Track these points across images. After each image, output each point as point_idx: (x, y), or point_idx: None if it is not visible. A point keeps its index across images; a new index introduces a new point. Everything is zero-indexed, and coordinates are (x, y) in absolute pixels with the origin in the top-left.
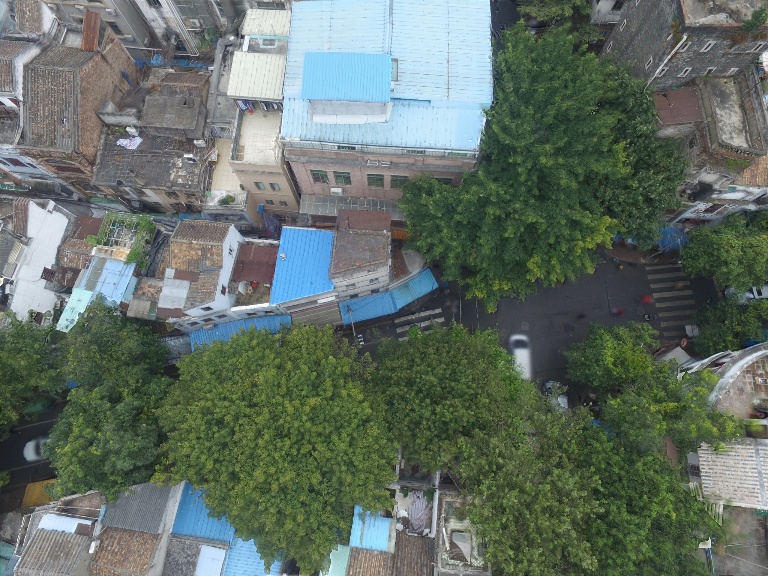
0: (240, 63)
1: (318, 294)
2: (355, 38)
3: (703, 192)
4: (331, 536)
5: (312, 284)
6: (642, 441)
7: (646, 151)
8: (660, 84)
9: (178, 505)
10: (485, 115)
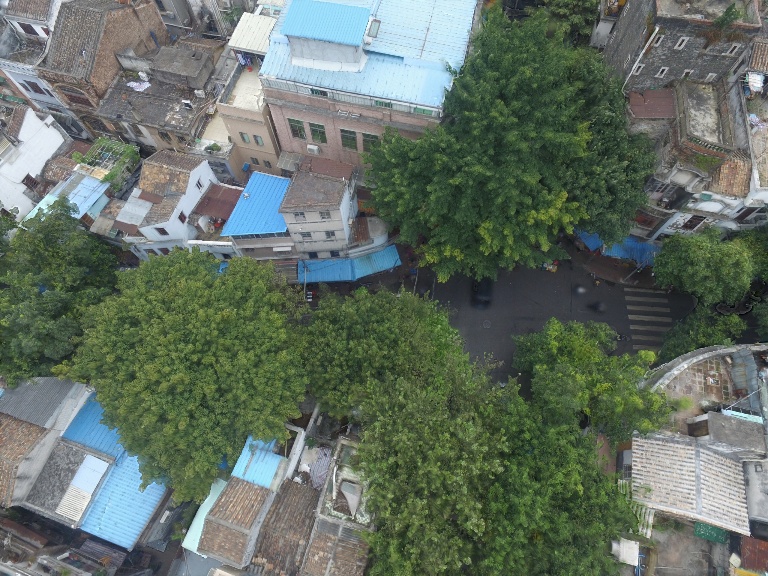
0: (246, 21)
1: (274, 240)
2: (347, 1)
3: (678, 199)
4: (213, 458)
5: (267, 223)
6: (564, 413)
7: (616, 141)
8: (638, 84)
9: (78, 411)
10: (448, 68)
